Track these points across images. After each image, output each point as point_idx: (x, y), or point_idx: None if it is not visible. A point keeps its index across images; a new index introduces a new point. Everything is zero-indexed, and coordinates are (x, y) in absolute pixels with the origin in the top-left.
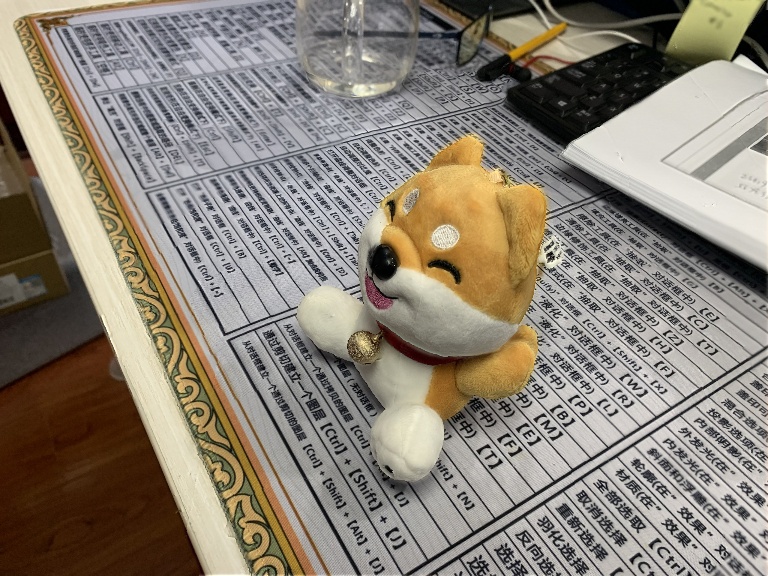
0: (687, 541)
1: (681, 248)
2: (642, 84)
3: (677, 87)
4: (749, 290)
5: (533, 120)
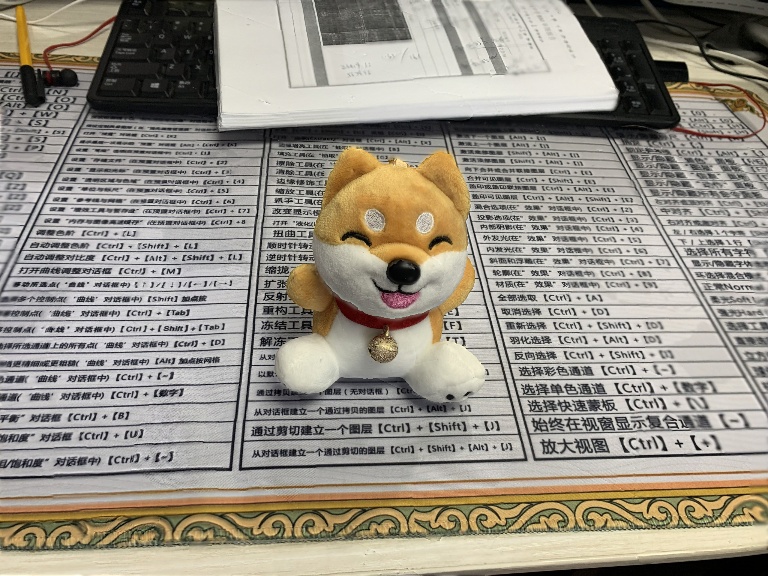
0: (550, 284)
1: (350, 139)
2: (189, 34)
3: (226, 24)
4: (407, 138)
5: (135, 114)
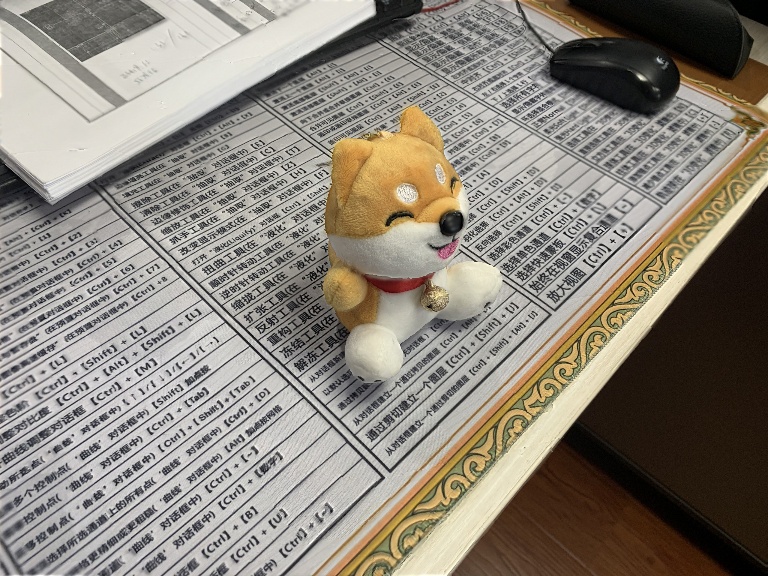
0: None
1: (178, 147)
2: None
3: None
4: (227, 119)
5: None
